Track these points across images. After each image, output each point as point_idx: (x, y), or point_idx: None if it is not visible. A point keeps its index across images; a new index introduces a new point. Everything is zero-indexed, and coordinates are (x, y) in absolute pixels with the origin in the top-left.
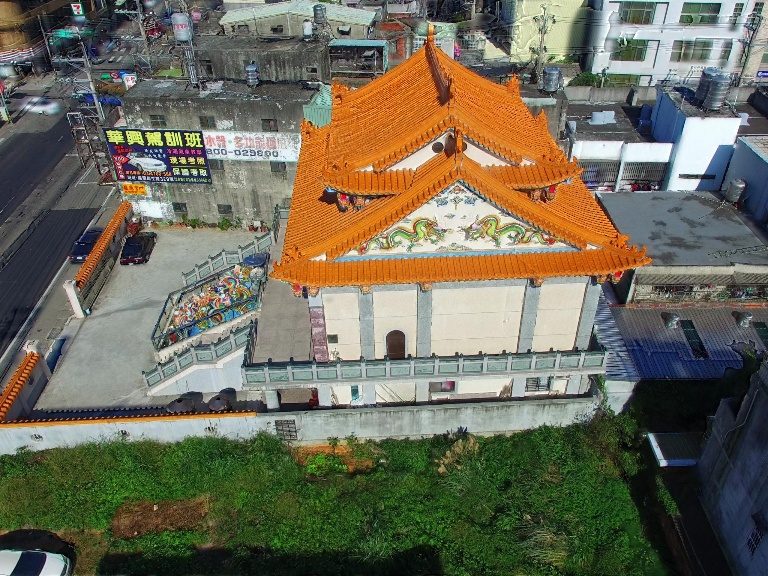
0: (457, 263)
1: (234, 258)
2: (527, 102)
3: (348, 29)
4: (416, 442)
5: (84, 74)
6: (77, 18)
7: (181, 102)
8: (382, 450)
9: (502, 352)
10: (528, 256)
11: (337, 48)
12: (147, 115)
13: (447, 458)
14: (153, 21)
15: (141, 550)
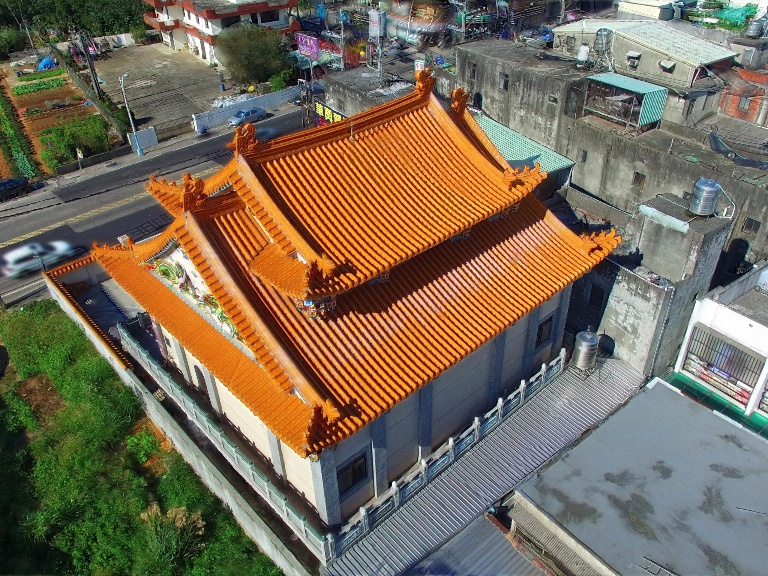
0: (200, 328)
1: None
2: (651, 215)
3: (670, 66)
4: (197, 485)
5: (339, 50)
6: (435, 2)
7: (353, 93)
8: (169, 468)
9: (269, 458)
10: (249, 363)
11: (597, 83)
12: (336, 97)
13: (150, 510)
14: (481, 16)
15: None
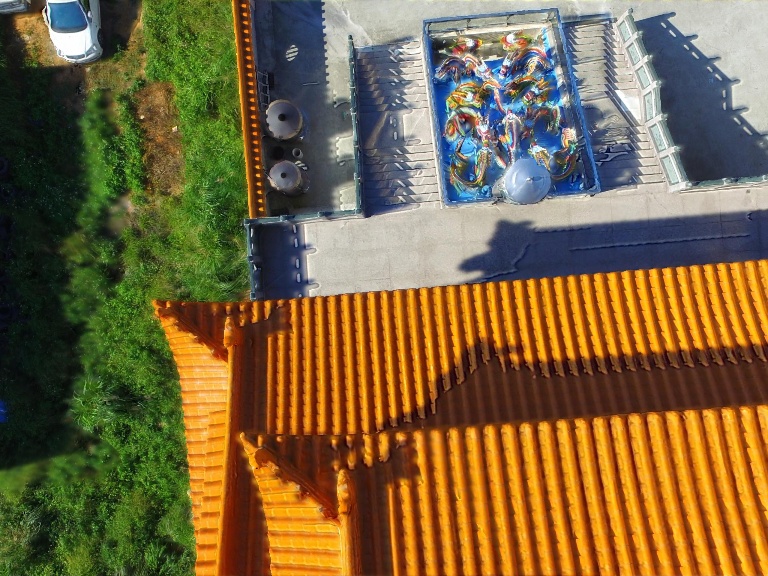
0: None
1: (653, 107)
2: None
3: None
4: None
5: None
6: None
7: None
8: None
9: None
10: None
11: None
12: None
13: None
14: None
15: (120, 131)
